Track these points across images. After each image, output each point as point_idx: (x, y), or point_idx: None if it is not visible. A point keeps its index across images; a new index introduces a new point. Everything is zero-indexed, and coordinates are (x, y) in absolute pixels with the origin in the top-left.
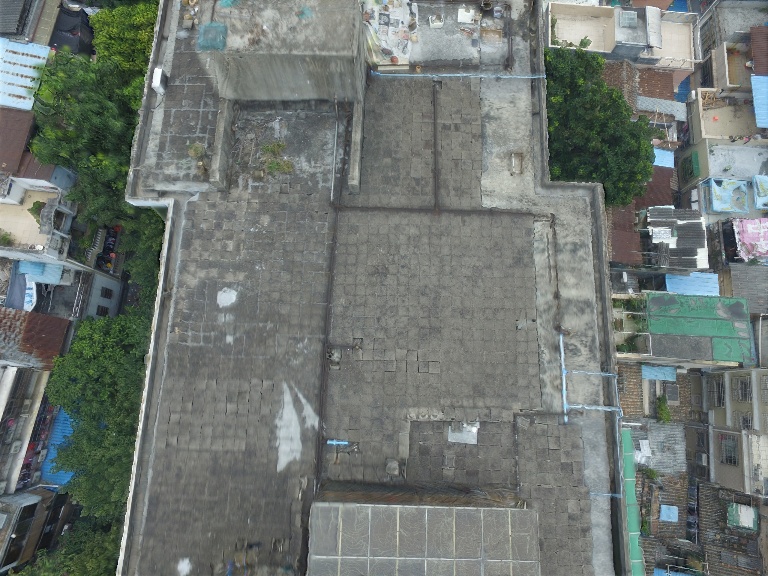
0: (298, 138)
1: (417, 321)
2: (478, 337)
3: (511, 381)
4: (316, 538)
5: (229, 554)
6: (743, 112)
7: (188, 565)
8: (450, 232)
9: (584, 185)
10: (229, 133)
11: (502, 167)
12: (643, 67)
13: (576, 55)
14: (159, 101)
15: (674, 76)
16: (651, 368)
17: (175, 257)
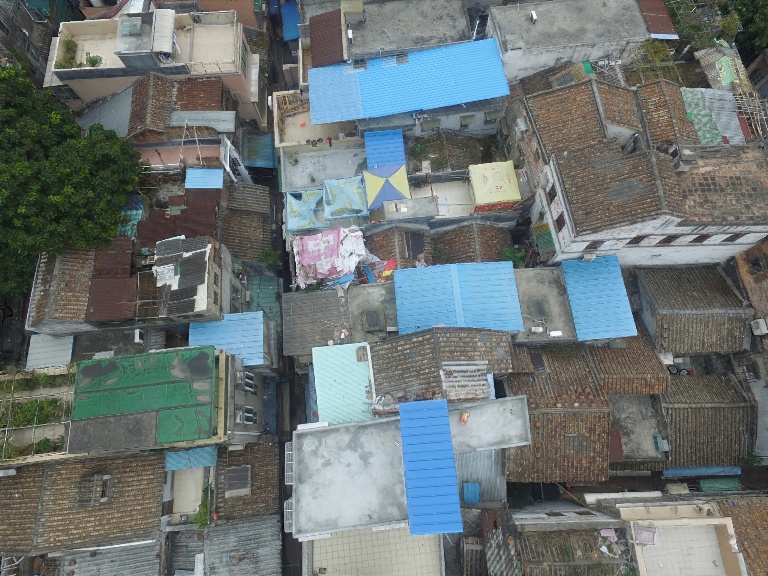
0: None
1: None
2: None
3: None
4: None
5: None
6: None
7: None
8: None
9: None
10: None
11: None
12: (181, 78)
13: None
14: None
15: (229, 83)
16: (180, 453)
17: None
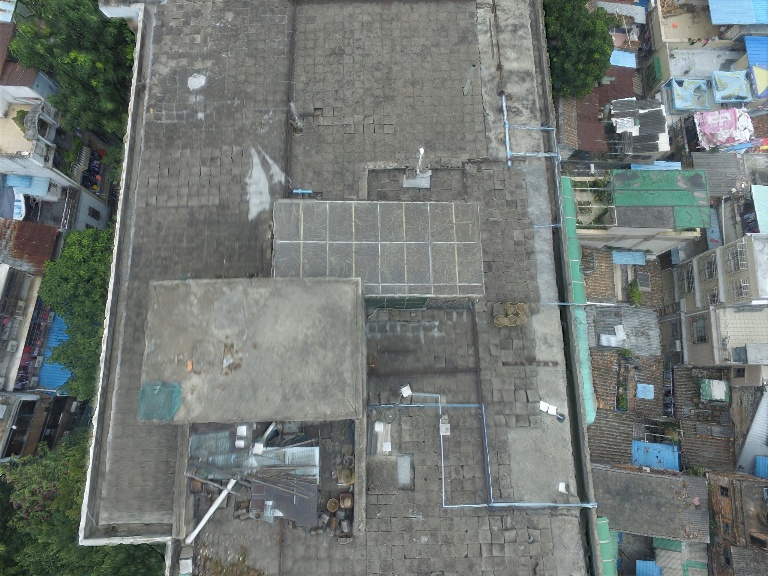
0: None
1: (372, 91)
2: (428, 103)
3: (459, 137)
4: (280, 227)
5: None
6: (701, 18)
7: None
8: (400, 18)
9: None
10: None
11: None
12: None
13: None
14: None
15: None
16: (621, 254)
17: (148, 57)
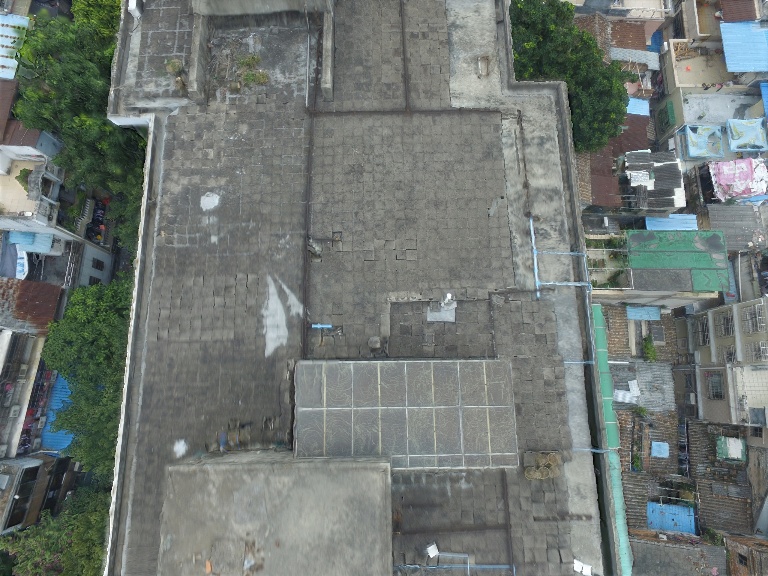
0: (272, 52)
1: (393, 213)
2: (452, 225)
3: (485, 264)
4: (302, 392)
5: (222, 434)
6: (715, 61)
7: (184, 446)
8: (422, 131)
9: (548, 83)
10: (205, 49)
11: (469, 71)
12: (615, 19)
13: (547, 3)
14: (136, 25)
15: (646, 27)
16: (636, 309)
17: (158, 170)
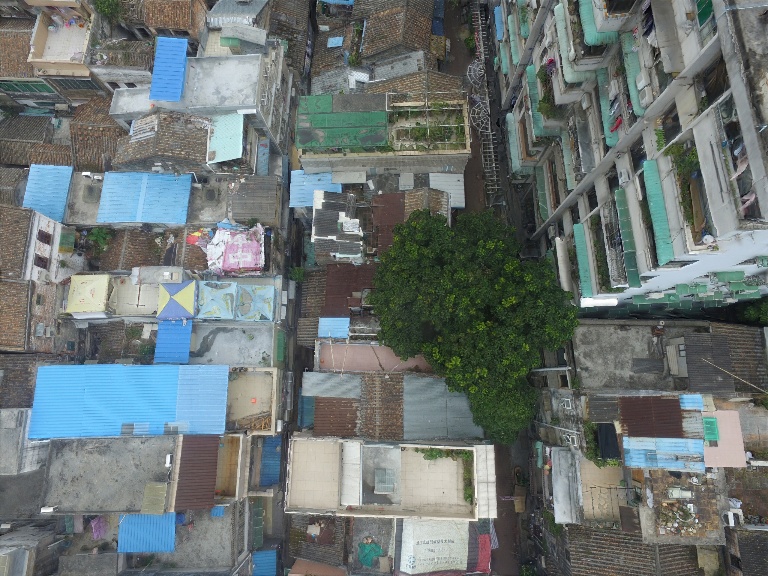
0: None
1: None
2: None
3: None
4: None
5: None
6: None
7: None
8: None
9: None
10: None
11: None
12: None
13: None
14: None
15: None
16: None
17: None
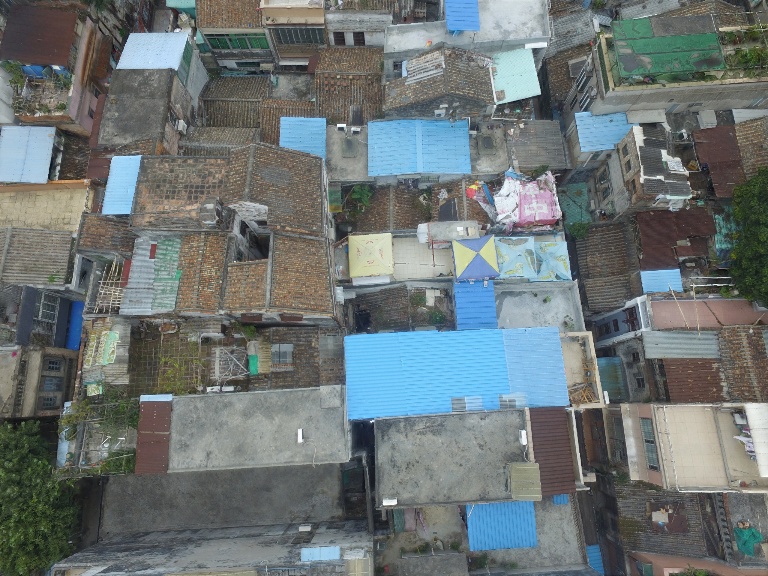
0: None
1: None
2: None
3: None
4: None
5: None
6: None
7: None
8: None
9: None
10: None
11: None
12: None
13: None
14: None
15: None
16: None
17: None
